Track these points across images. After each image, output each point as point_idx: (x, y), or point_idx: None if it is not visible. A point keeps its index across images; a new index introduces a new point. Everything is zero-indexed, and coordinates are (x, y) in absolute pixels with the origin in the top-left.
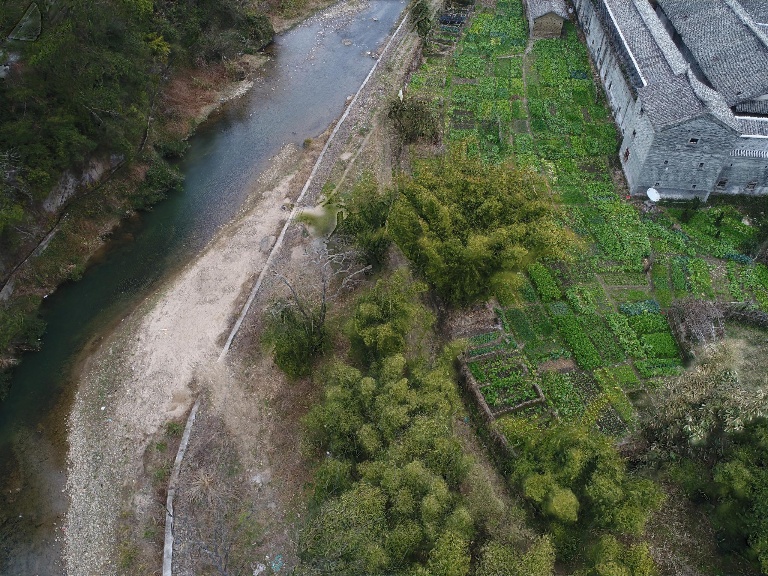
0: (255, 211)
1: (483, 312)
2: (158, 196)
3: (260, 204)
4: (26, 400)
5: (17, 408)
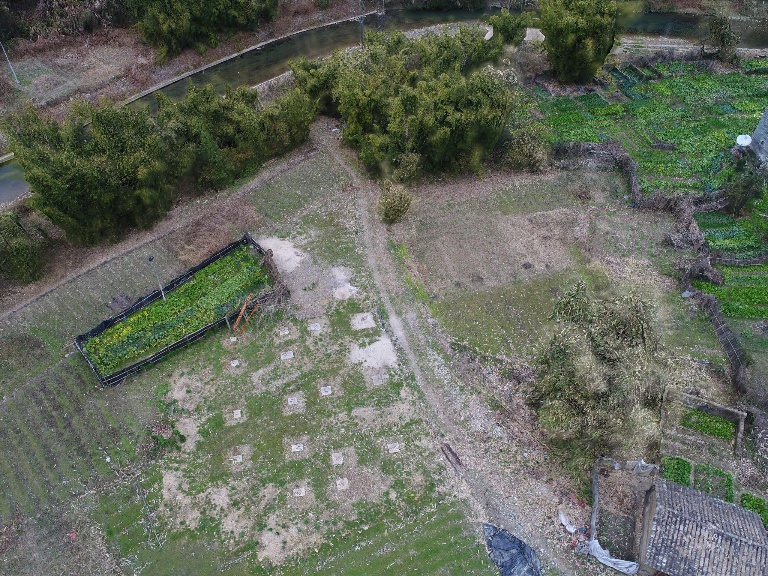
0: None
1: (563, 91)
2: None
3: None
4: (446, 17)
5: (442, 16)
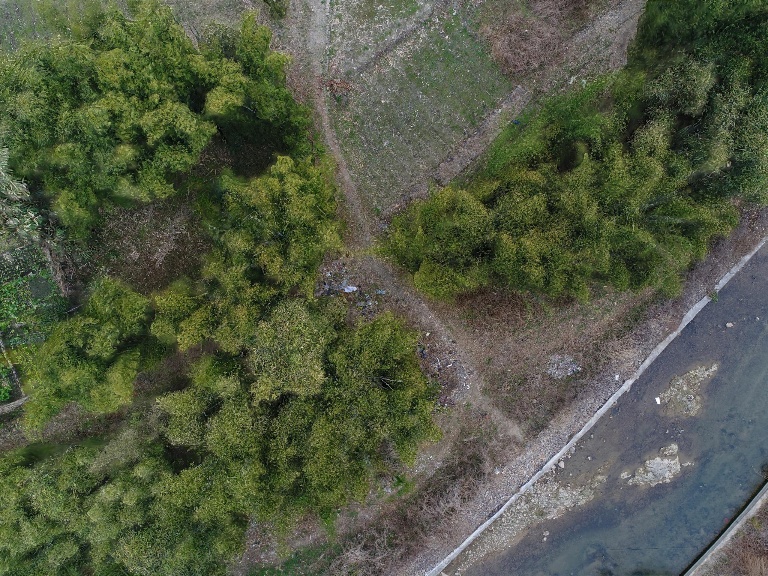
0: None
1: None
2: None
3: None
4: None
5: None
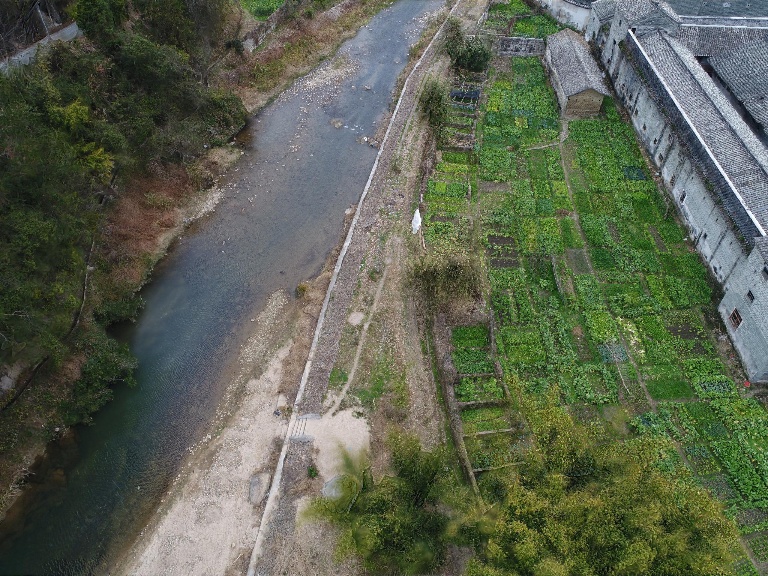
0: (238, 418)
1: None
2: (100, 400)
3: (244, 405)
4: None
5: None
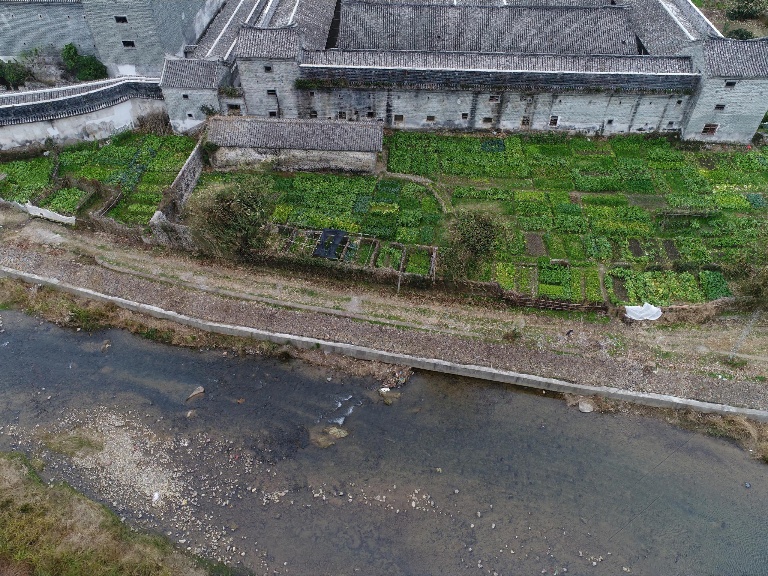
0: None
1: None
2: None
3: None
4: None
5: None
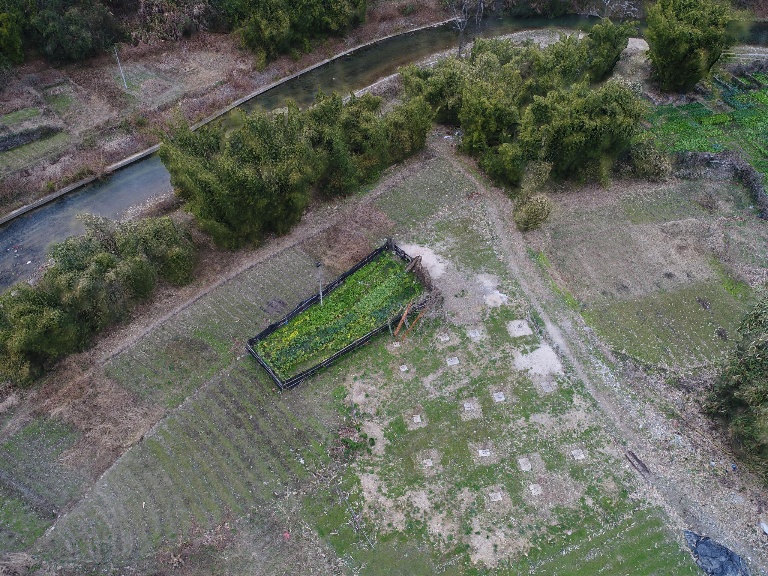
0: None
1: (665, 100)
2: None
3: None
4: None
5: (522, 23)
